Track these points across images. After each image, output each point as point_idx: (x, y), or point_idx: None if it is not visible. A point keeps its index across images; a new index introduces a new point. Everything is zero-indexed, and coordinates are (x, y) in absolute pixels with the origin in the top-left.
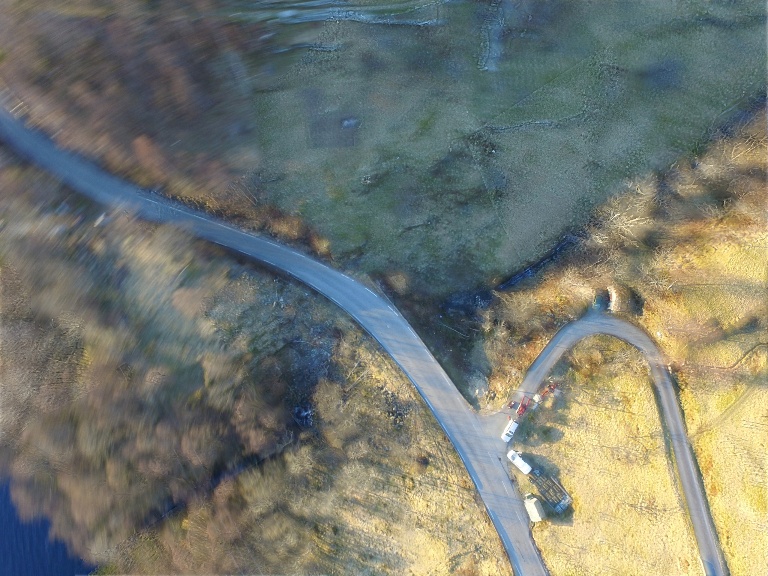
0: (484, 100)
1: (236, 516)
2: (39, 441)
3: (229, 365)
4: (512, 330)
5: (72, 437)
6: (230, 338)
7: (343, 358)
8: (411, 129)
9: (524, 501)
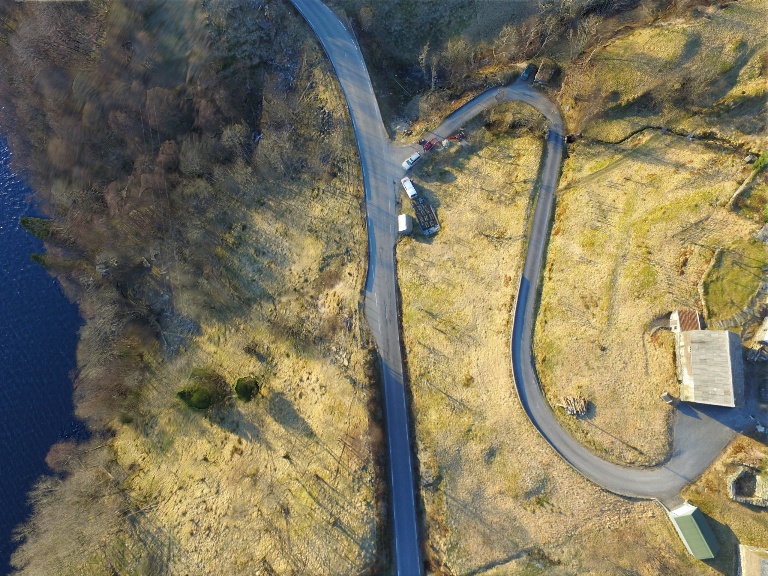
0: None
1: (168, 176)
2: (43, 84)
3: (209, 62)
4: None
5: (69, 90)
6: (217, 35)
7: (301, 81)
8: None
9: None
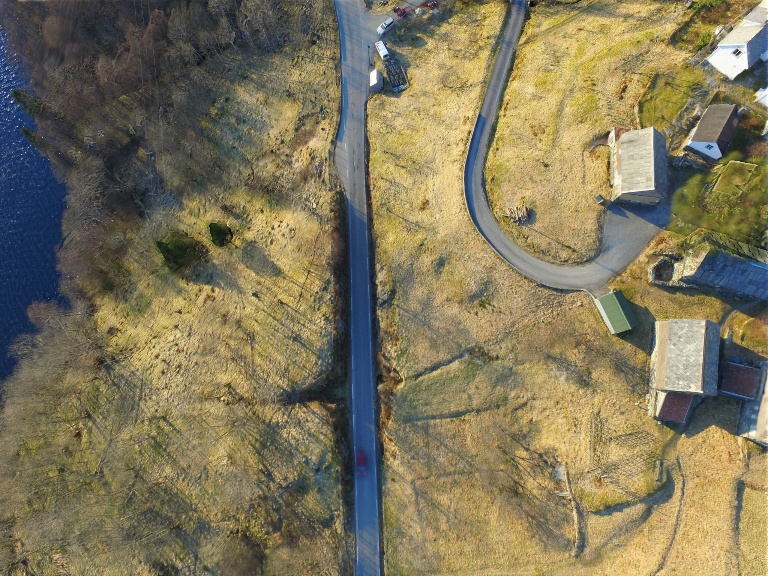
0: None
1: (156, 44)
2: None
3: None
4: None
5: None
6: None
7: None
8: None
9: None
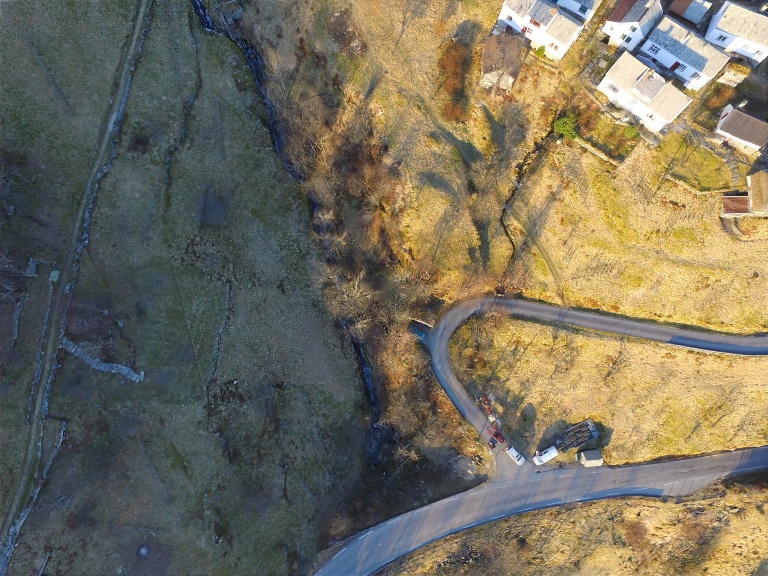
0: (177, 384)
1: None
2: None
3: None
4: (420, 415)
5: None
6: None
7: None
8: (179, 474)
9: (581, 464)
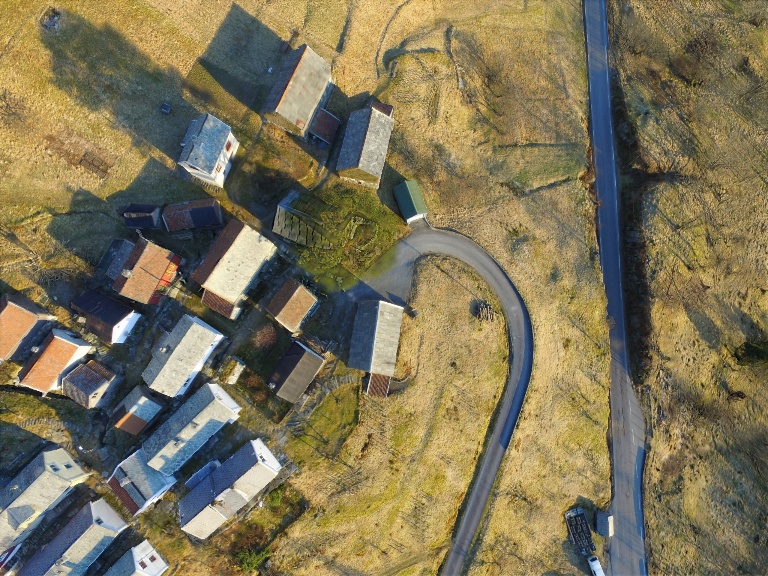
0: None
1: None
2: None
3: None
4: None
5: None
6: None
7: None
8: None
9: None
